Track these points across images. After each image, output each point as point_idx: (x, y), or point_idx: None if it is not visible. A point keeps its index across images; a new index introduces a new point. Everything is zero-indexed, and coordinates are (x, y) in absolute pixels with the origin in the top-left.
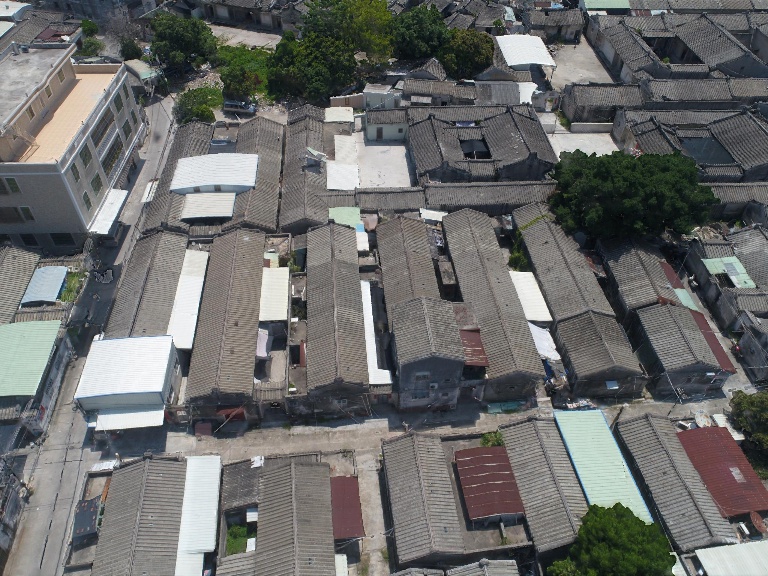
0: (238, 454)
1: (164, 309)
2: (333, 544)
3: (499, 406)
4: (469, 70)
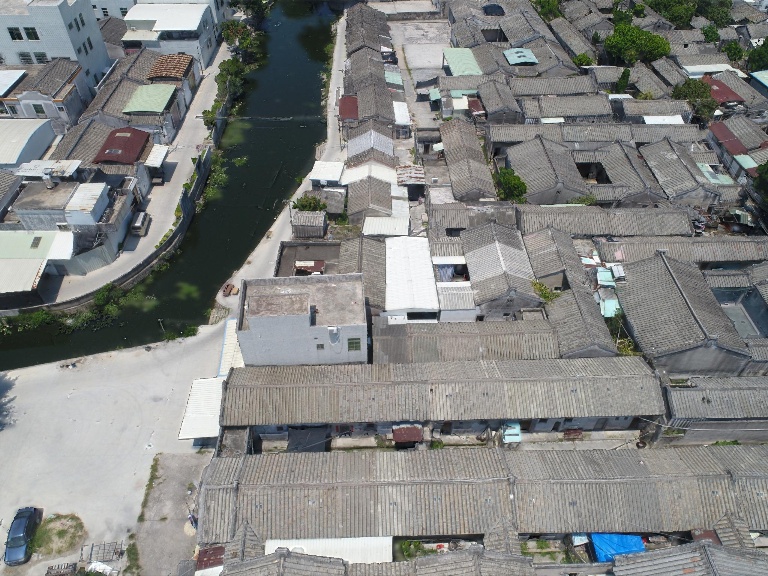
0: None
1: None
2: None
3: None
4: None
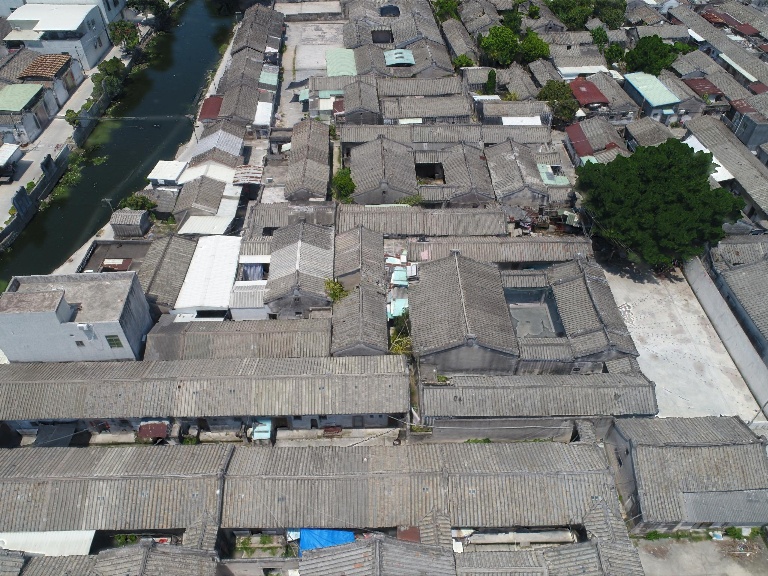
0: None
1: None
2: (761, 81)
3: None
4: None
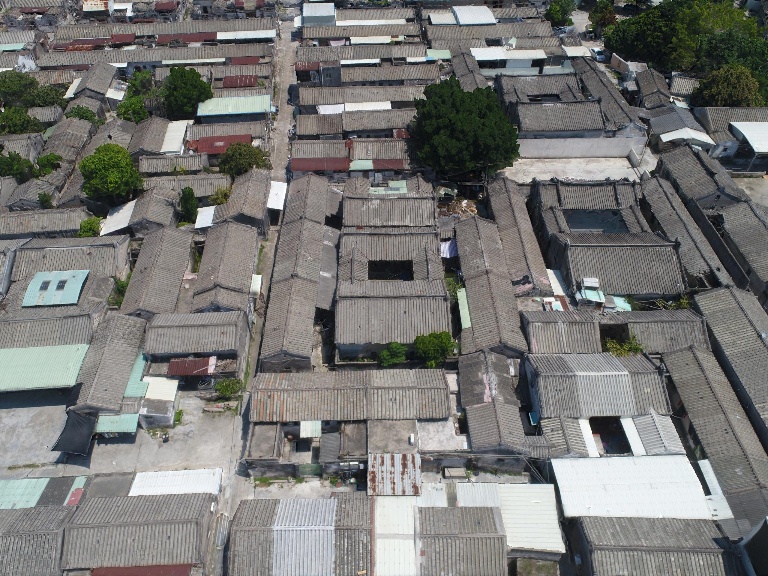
0: None
1: (358, 17)
2: (229, 57)
3: (297, 109)
4: (701, 102)
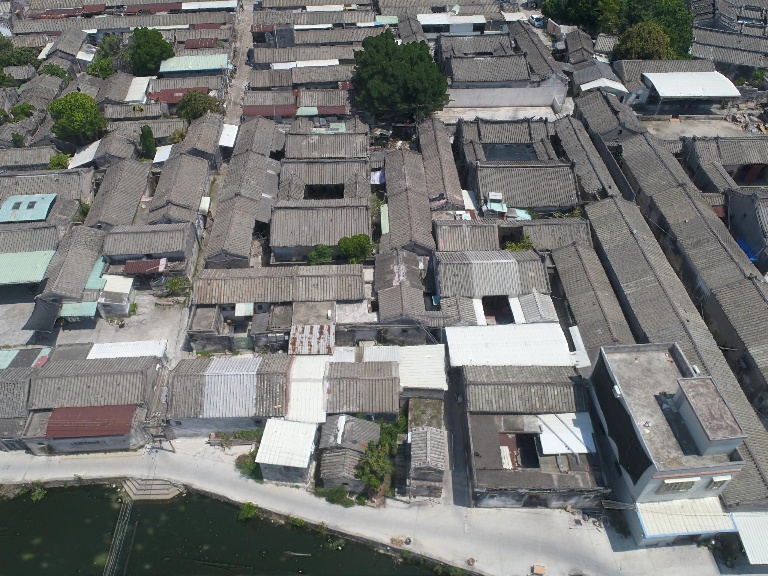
0: (249, 23)
1: None
2: (192, 24)
3: None
4: (620, 56)
